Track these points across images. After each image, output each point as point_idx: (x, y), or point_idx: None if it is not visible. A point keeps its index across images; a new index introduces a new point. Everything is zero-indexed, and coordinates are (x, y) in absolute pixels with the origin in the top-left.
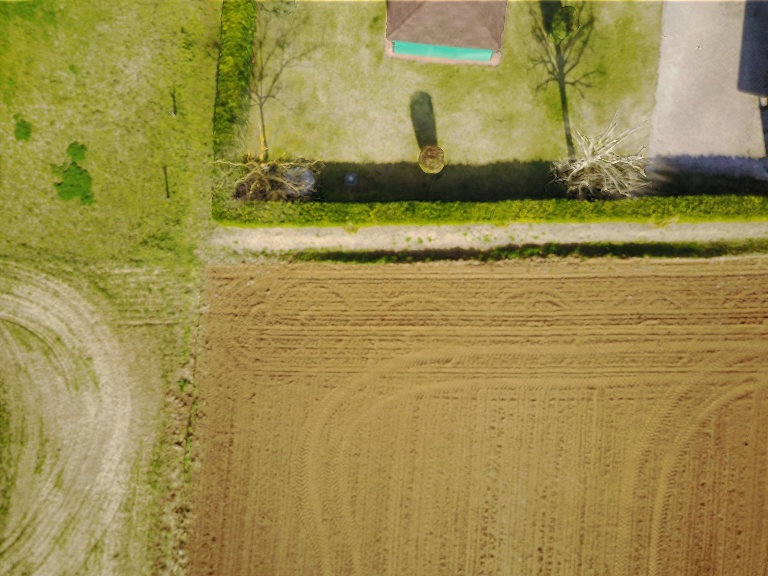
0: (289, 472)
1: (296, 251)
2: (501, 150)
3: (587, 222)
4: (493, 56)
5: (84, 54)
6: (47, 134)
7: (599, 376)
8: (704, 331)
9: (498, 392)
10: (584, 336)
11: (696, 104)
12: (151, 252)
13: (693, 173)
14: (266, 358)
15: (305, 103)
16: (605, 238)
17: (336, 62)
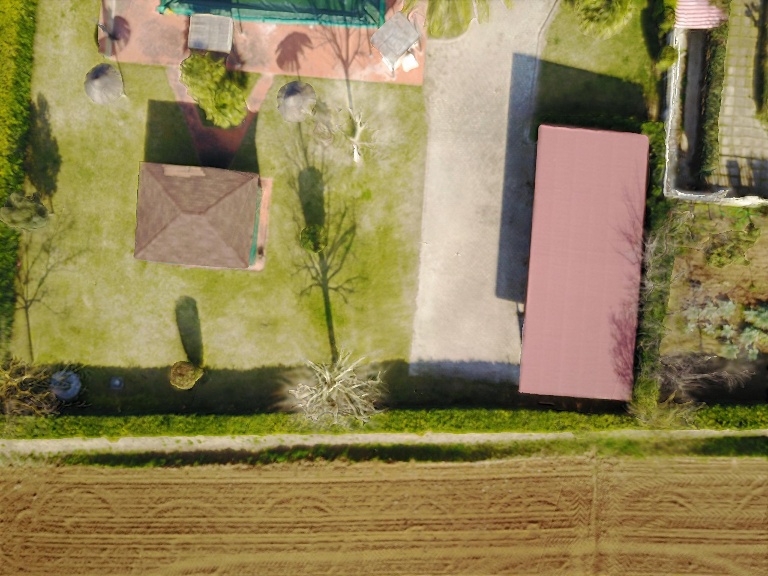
0: None
1: (65, 453)
2: (267, 354)
3: None
4: (257, 261)
5: None
6: None
7: None
8: (469, 537)
9: None
10: (351, 543)
11: (456, 310)
12: None
13: (455, 378)
14: (30, 567)
15: (70, 307)
16: (374, 439)
17: (101, 266)
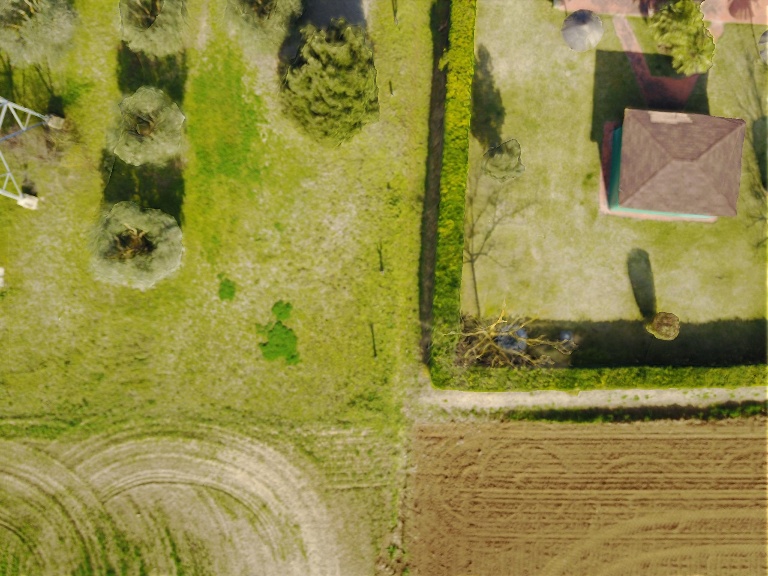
0: None
1: (507, 409)
2: (722, 307)
3: None
4: None
5: (289, 211)
6: (252, 293)
7: None
8: None
9: (728, 559)
10: None
11: None
12: (359, 413)
13: None
14: (481, 523)
15: (519, 261)
16: None
17: (550, 219)
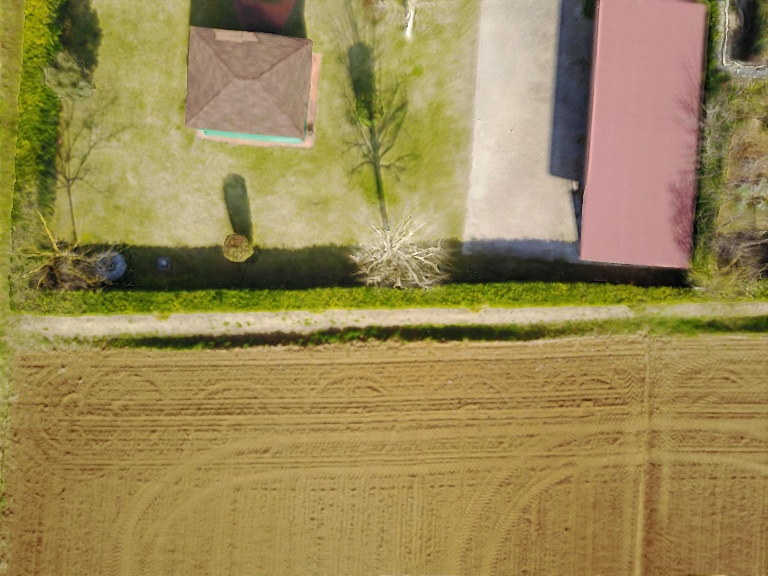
0: (100, 572)
1: (110, 337)
2: (318, 233)
3: (400, 309)
4: (307, 138)
5: None
6: None
7: (419, 463)
8: (523, 415)
9: (317, 482)
10: (404, 422)
11: (510, 187)
12: None
13: (509, 256)
14: (77, 451)
15: (114, 186)
16: (426, 321)
17: (146, 143)
